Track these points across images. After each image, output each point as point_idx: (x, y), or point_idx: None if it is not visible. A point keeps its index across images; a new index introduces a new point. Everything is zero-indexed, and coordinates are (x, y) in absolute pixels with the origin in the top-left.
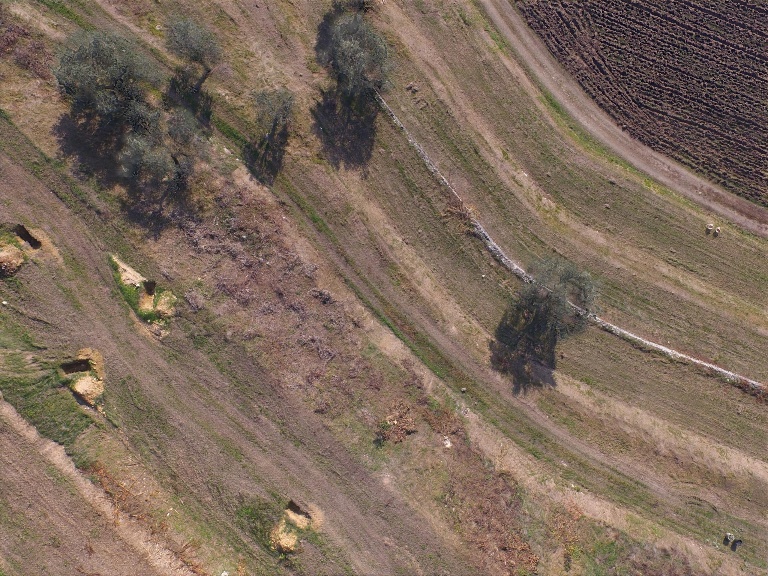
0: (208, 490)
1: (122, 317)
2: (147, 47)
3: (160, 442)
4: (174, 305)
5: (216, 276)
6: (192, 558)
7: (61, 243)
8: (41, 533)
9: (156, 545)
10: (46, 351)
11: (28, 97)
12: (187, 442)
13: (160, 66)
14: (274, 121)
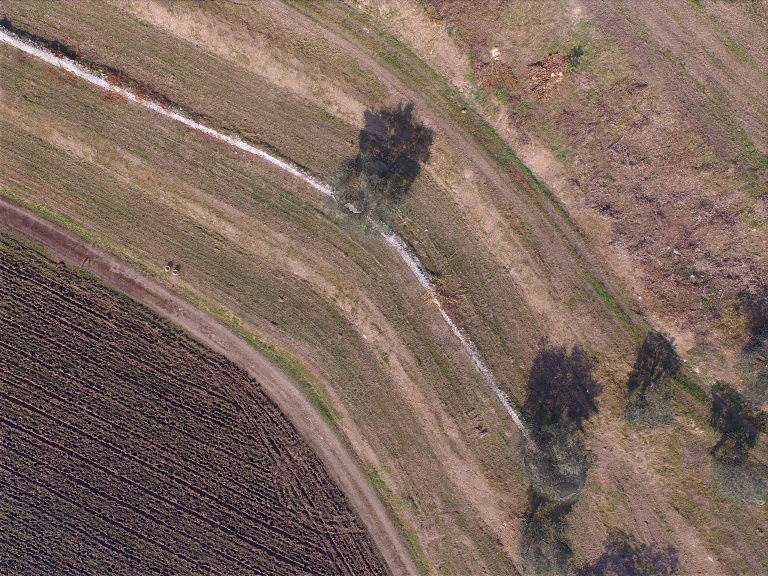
0: (765, 11)
1: None
2: None
3: None
4: None
5: (733, 234)
6: None
7: None
8: None
9: None
10: None
11: None
12: None
13: (765, 461)
14: (643, 399)
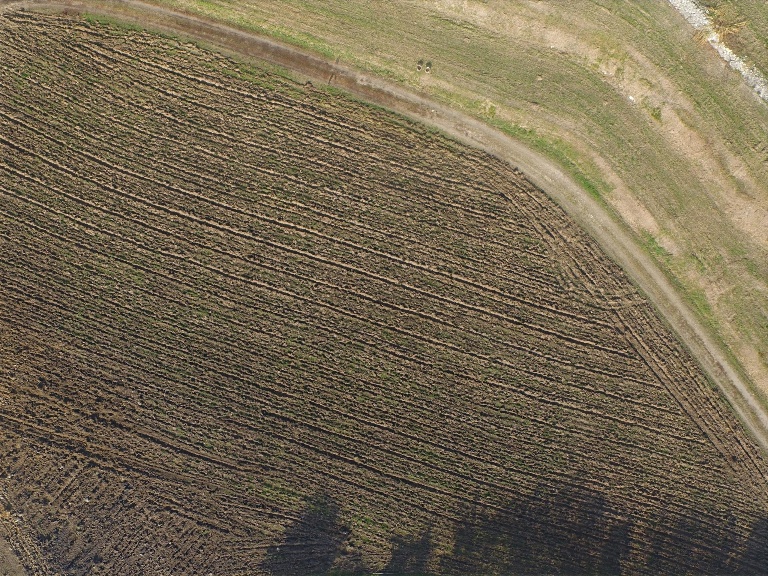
0: None
1: None
2: None
3: None
4: None
5: None
6: None
7: None
8: None
9: None
10: None
11: None
12: None
13: None
14: None
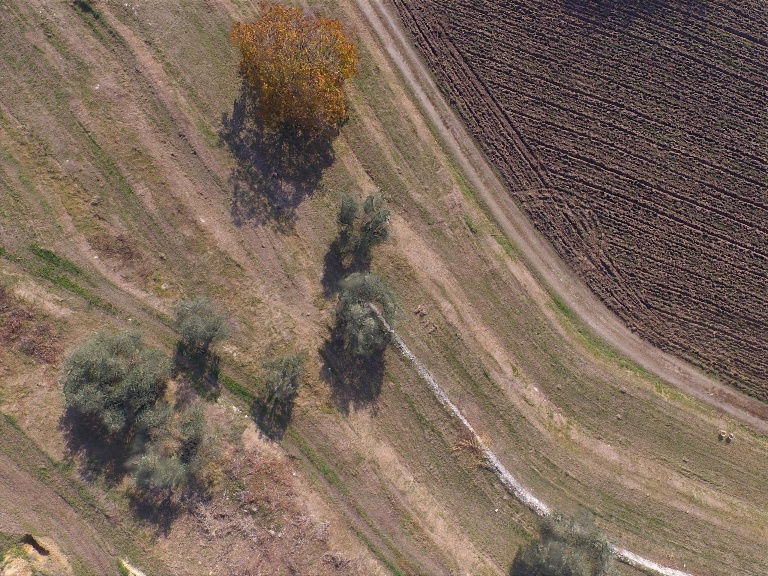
0: None
1: None
2: (153, 313)
3: None
4: None
5: (228, 565)
6: None
7: (70, 551)
8: None
9: None
10: None
11: (34, 389)
12: None
13: (167, 330)
14: None
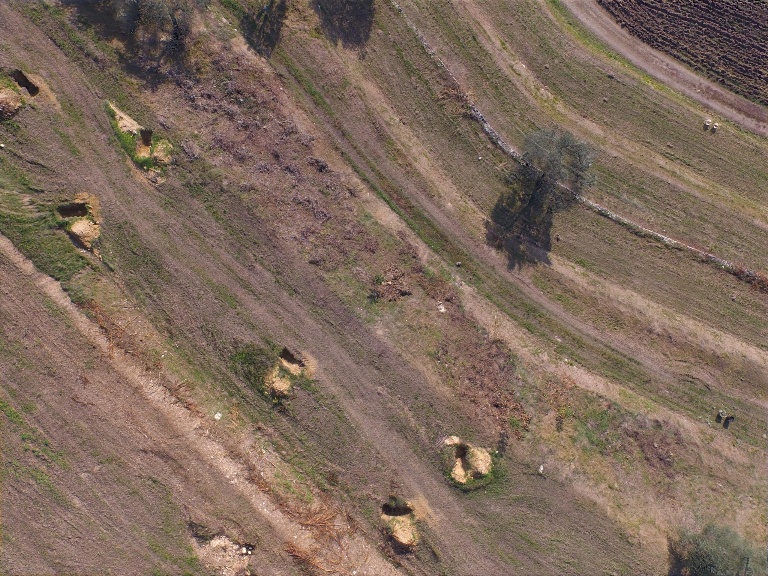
0: (203, 335)
1: (119, 164)
2: None
3: (155, 287)
4: (170, 153)
5: (213, 132)
6: (186, 397)
7: (59, 89)
8: (37, 362)
9: (150, 380)
10: (43, 194)
11: None
12: (182, 287)
13: None
14: None
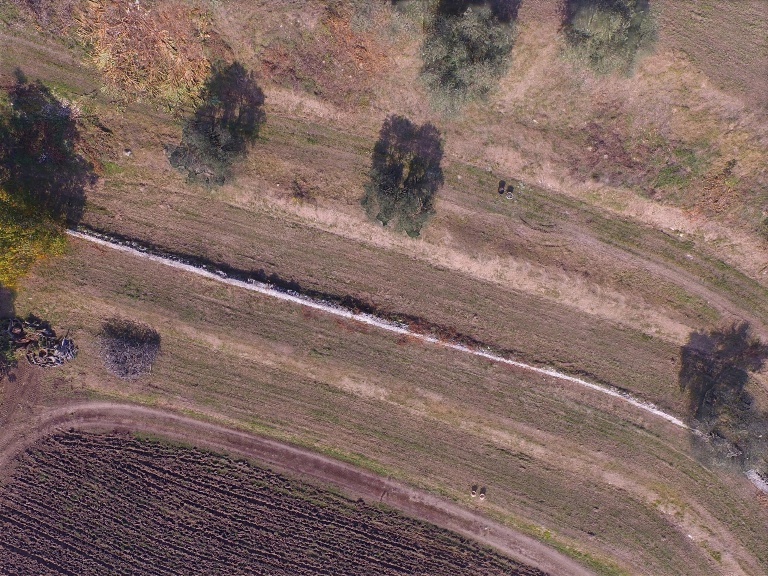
0: None
1: None
2: None
3: None
4: None
5: None
6: None
7: None
8: None
9: None
10: None
11: None
12: None
13: None
14: None
